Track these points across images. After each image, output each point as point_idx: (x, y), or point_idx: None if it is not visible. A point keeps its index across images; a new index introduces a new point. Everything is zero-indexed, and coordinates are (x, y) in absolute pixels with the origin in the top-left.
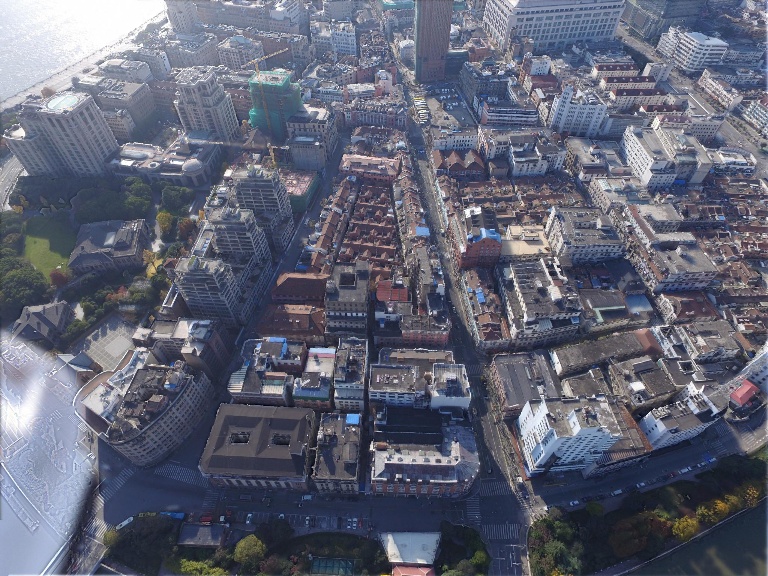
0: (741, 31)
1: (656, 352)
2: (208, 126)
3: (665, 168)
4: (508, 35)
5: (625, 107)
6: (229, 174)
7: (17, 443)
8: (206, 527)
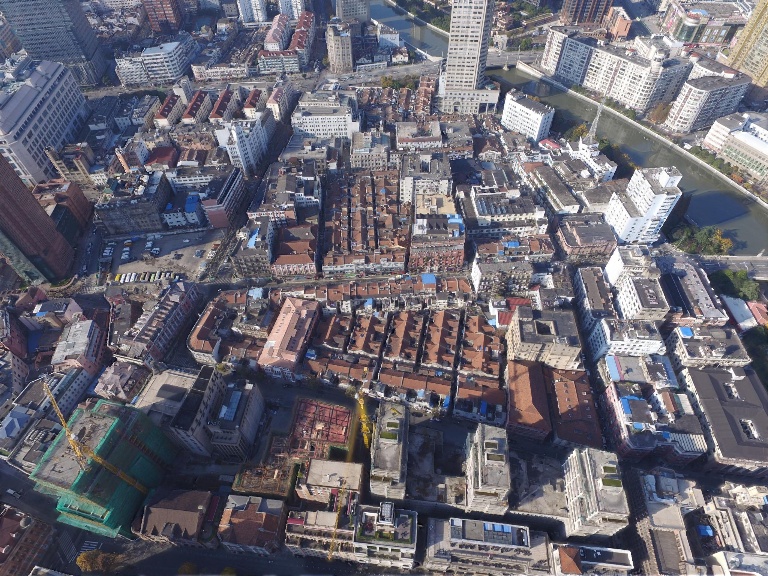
0: (128, 38)
1: (544, 164)
2: None
3: None
4: (29, 166)
5: None
6: (330, 516)
7: None
8: None
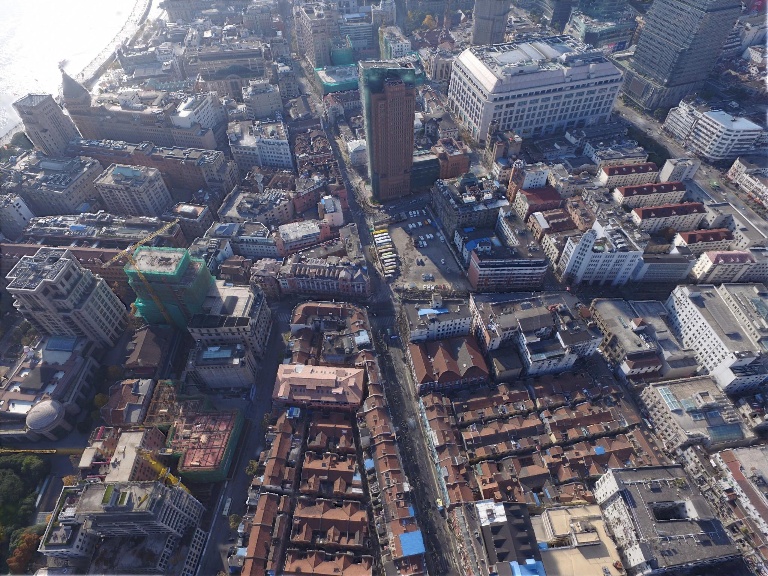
0: (755, 93)
1: None
2: (73, 331)
3: (750, 362)
4: (484, 124)
5: (653, 229)
6: (88, 460)
7: None
8: None
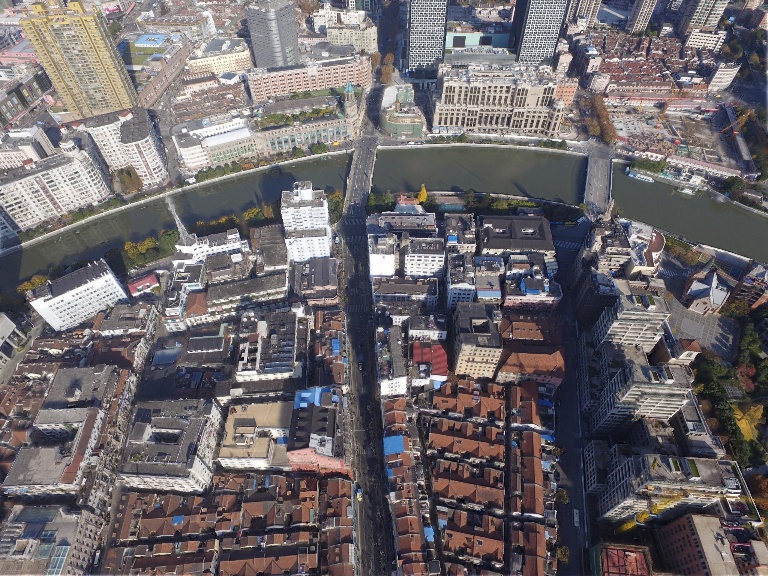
0: None
1: None
2: None
3: None
4: None
5: None
6: (758, 548)
7: (697, 258)
8: (530, 213)
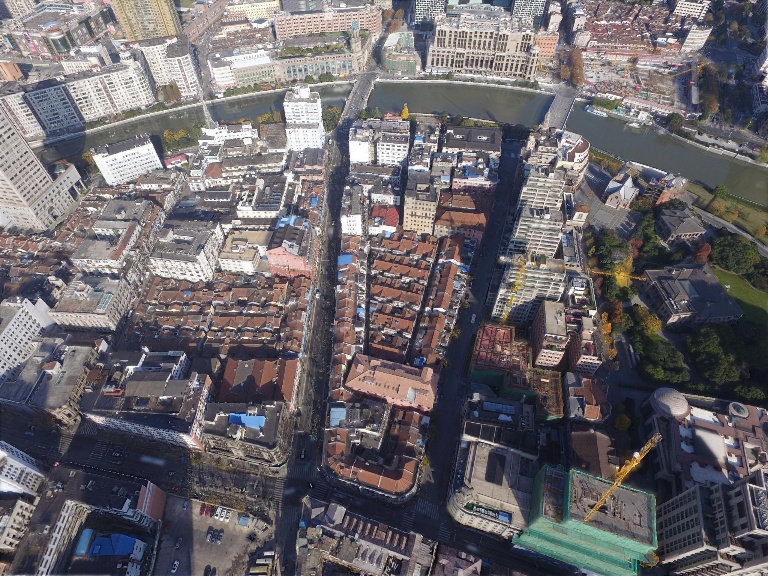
0: None
1: None
2: None
3: None
4: None
5: None
6: (586, 321)
7: None
8: None
